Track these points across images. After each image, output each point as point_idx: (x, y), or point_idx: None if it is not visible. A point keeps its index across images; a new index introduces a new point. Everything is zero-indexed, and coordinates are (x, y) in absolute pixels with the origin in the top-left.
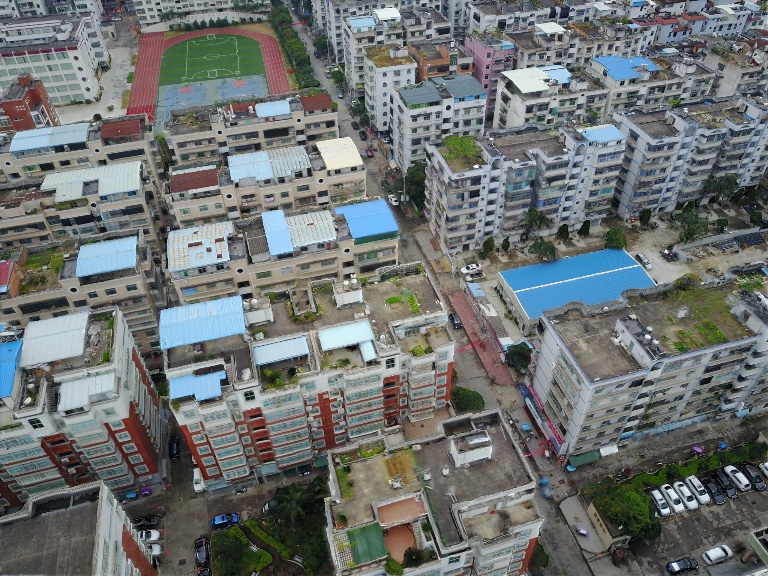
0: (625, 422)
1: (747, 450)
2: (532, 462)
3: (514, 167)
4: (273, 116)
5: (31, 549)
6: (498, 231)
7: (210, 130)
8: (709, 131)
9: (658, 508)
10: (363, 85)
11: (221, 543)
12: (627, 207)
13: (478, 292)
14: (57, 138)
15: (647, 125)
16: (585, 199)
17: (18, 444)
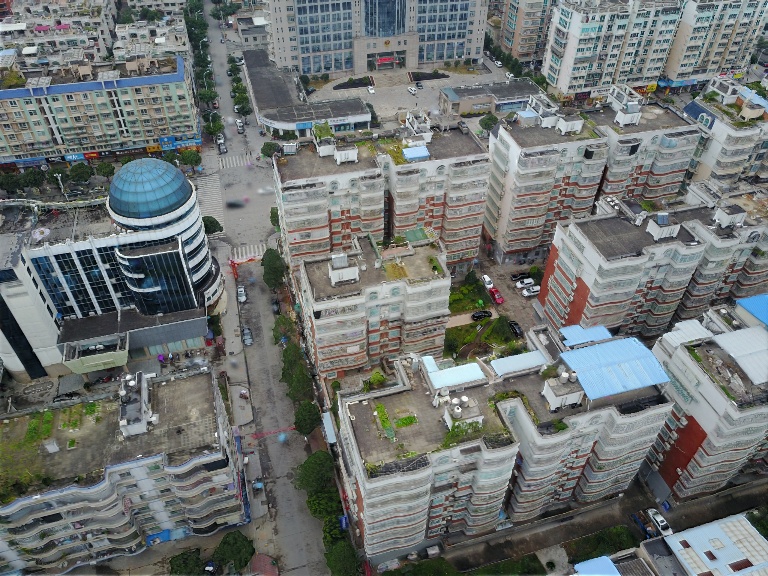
0: None
1: None
2: (263, 458)
3: None
4: None
5: (624, 237)
6: None
7: None
8: None
9: None
10: None
11: None
12: None
13: None
14: None
15: None
16: None
17: None
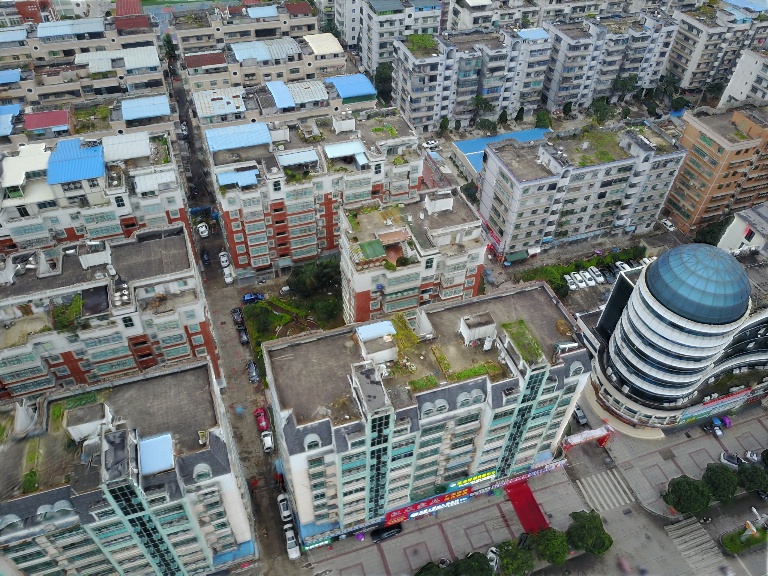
0: (545, 226)
1: (631, 251)
2: None
3: (464, 57)
4: (263, 17)
5: (142, 257)
6: (451, 115)
7: (210, 27)
8: (616, 36)
9: (568, 285)
10: (331, 8)
11: (253, 307)
12: (553, 101)
13: None
14: (78, 28)
15: (569, 31)
16: (520, 90)
17: (105, 220)
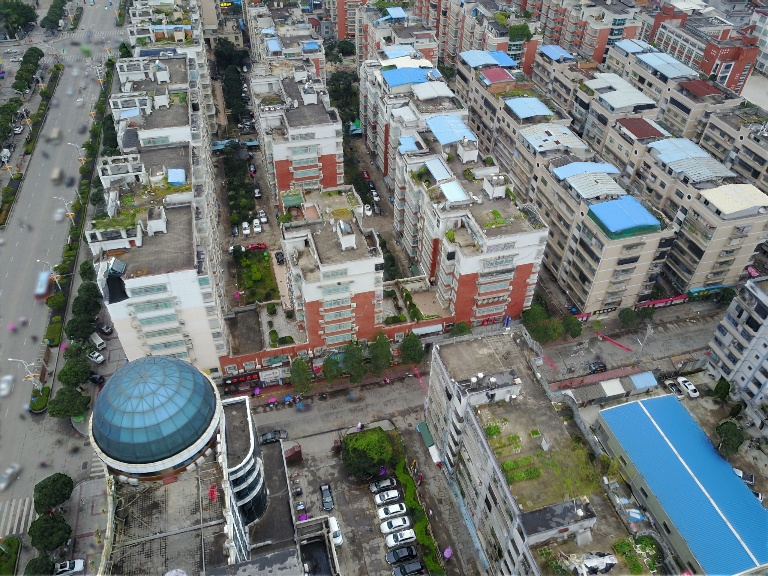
0: None
1: None
2: None
3: None
4: None
5: (310, 114)
6: (760, 403)
7: (737, 130)
8: None
9: (381, 492)
10: None
11: None
12: None
13: (640, 381)
14: (664, 66)
15: None
16: None
17: None
